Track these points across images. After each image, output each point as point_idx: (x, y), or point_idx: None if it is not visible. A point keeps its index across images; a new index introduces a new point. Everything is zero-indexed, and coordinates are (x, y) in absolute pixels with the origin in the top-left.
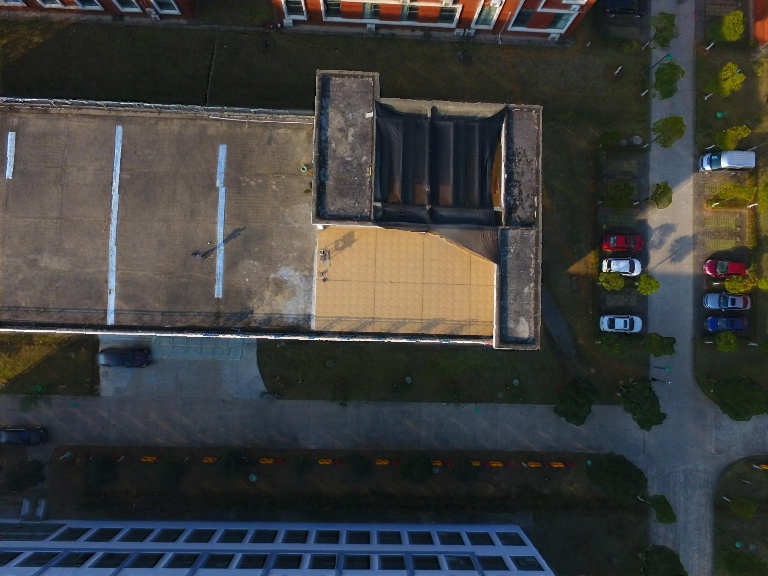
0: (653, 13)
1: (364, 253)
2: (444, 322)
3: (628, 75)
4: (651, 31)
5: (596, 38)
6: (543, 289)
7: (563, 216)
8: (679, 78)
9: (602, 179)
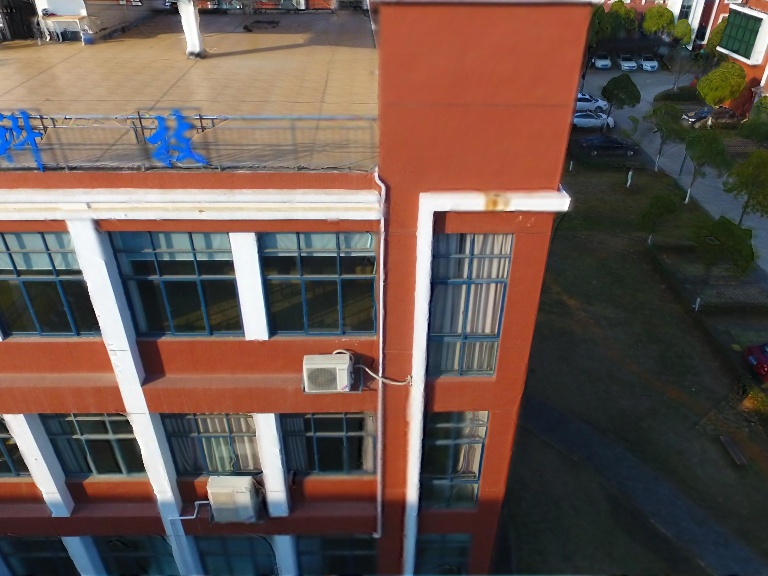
0: (651, 154)
1: (1, 75)
2: (204, 147)
3: (650, 189)
4: (658, 164)
5: (580, 165)
6: (650, 474)
7: (629, 334)
8: (728, 155)
9: (681, 285)
